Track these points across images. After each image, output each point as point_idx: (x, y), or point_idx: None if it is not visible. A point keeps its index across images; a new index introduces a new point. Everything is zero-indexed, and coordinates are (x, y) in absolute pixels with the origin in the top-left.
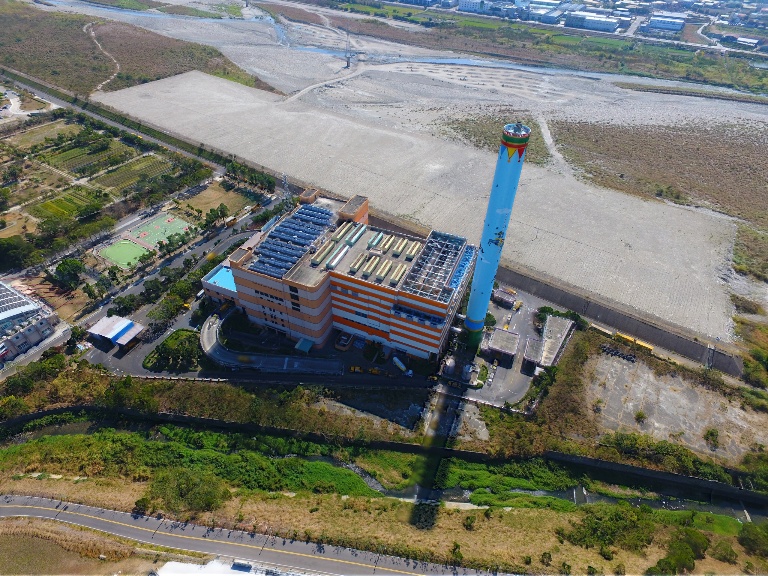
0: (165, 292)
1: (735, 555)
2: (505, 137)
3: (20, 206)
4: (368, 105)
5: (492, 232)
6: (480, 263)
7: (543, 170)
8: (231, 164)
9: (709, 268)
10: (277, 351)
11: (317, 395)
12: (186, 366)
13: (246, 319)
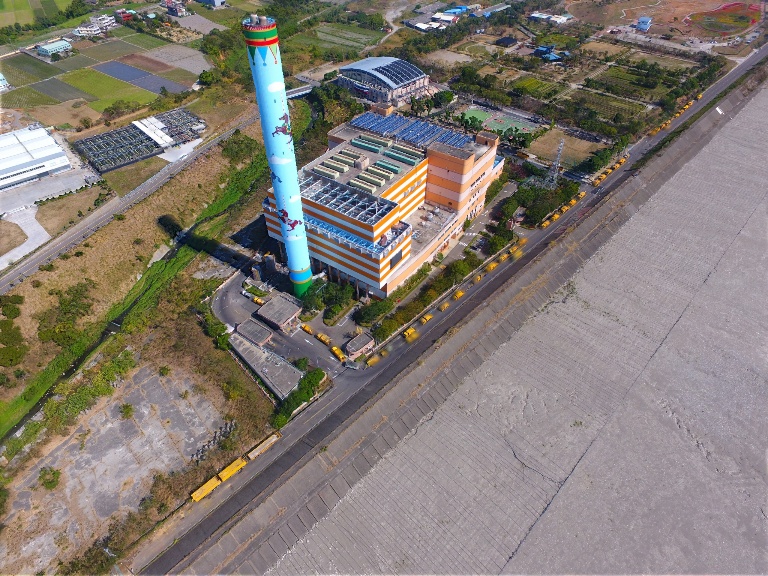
0: None
1: None
2: None
3: (526, 72)
4: None
5: None
6: None
7: None
8: None
9: None
10: None
11: None
12: None
13: None
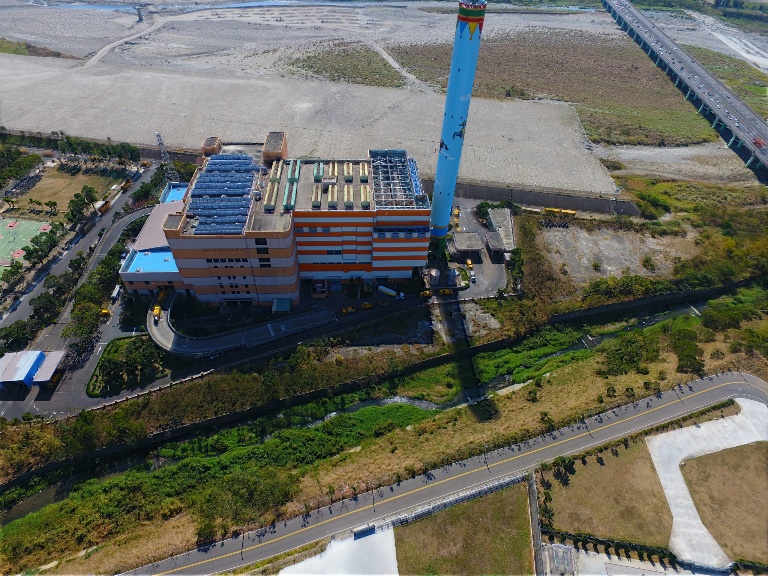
0: (63, 306)
1: (714, 334)
2: (465, 12)
3: None
4: (192, 57)
5: (456, 124)
6: (444, 162)
7: (406, 91)
8: (66, 141)
9: (575, 143)
10: (252, 322)
11: (323, 348)
12: (149, 375)
13: (196, 301)
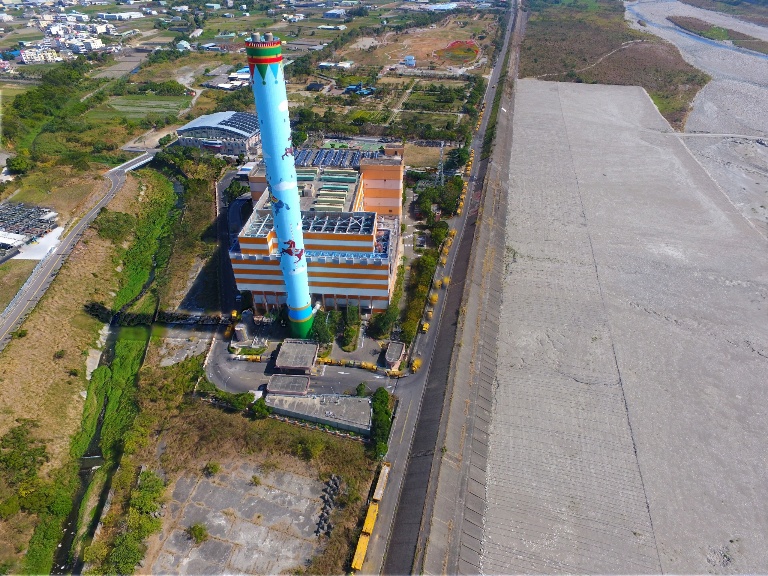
0: None
1: None
2: None
3: None
4: (762, 174)
5: None
6: None
7: None
8: None
9: None
10: None
11: None
12: None
13: None
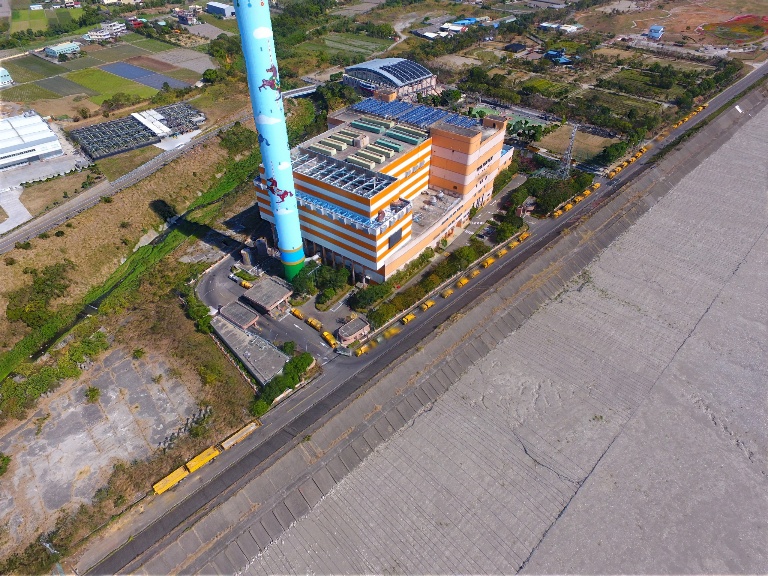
0: None
1: None
2: None
3: None
4: None
5: None
6: None
7: None
8: None
9: None
10: None
11: None
12: None
13: None
